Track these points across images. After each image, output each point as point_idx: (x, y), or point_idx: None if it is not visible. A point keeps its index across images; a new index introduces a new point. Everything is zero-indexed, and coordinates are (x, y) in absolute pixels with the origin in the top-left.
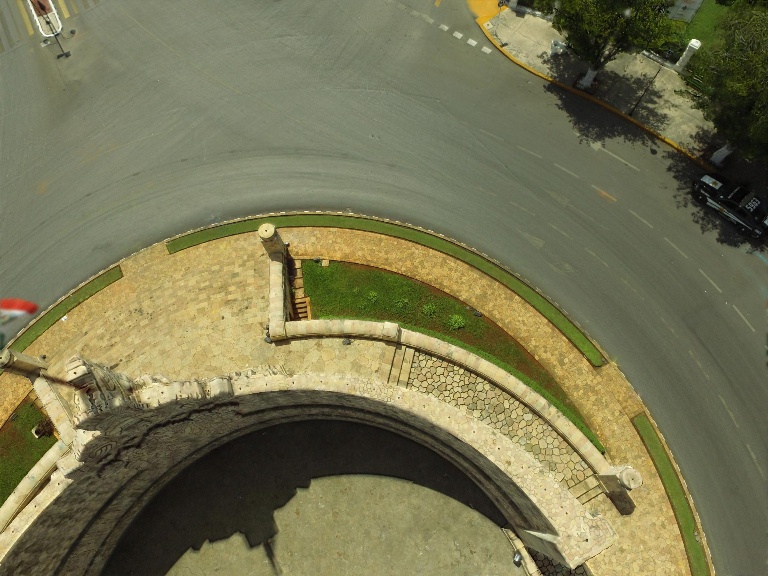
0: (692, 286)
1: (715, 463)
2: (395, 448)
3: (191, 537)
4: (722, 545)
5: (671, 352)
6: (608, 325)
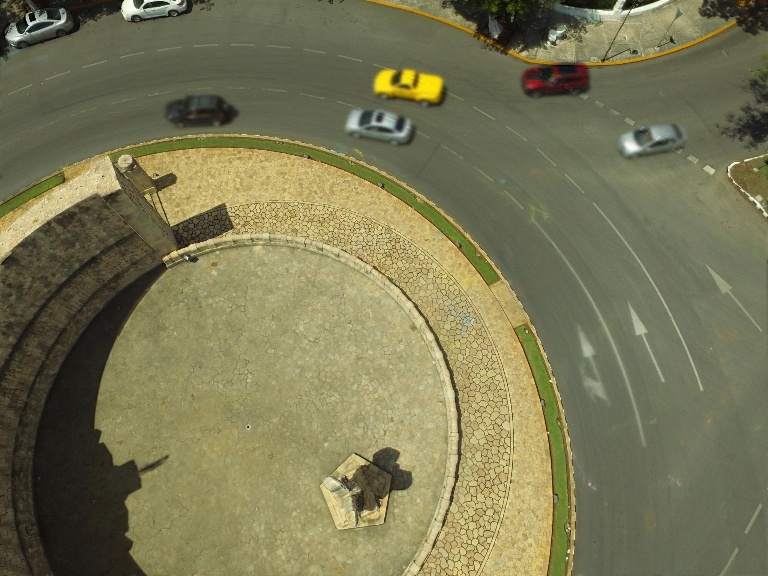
0: (20, 102)
1: (156, 118)
2: (86, 350)
3: (119, 552)
4: (210, 126)
5: (68, 128)
6: (32, 167)
